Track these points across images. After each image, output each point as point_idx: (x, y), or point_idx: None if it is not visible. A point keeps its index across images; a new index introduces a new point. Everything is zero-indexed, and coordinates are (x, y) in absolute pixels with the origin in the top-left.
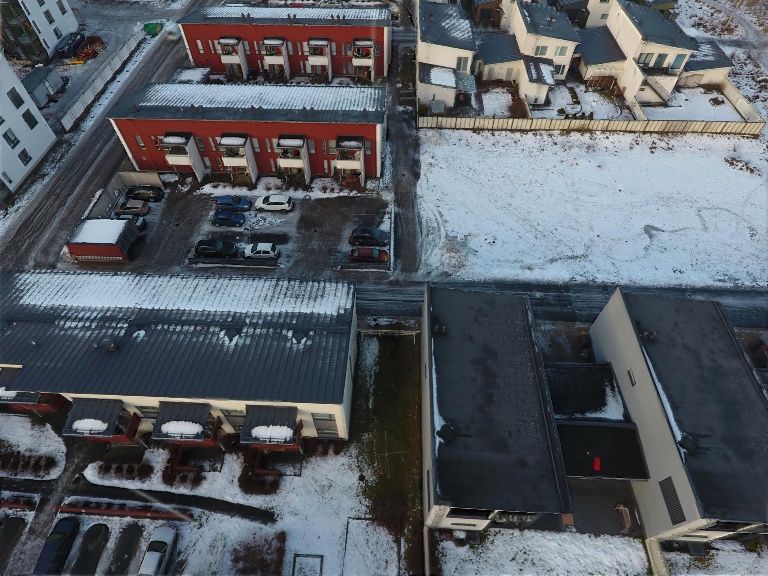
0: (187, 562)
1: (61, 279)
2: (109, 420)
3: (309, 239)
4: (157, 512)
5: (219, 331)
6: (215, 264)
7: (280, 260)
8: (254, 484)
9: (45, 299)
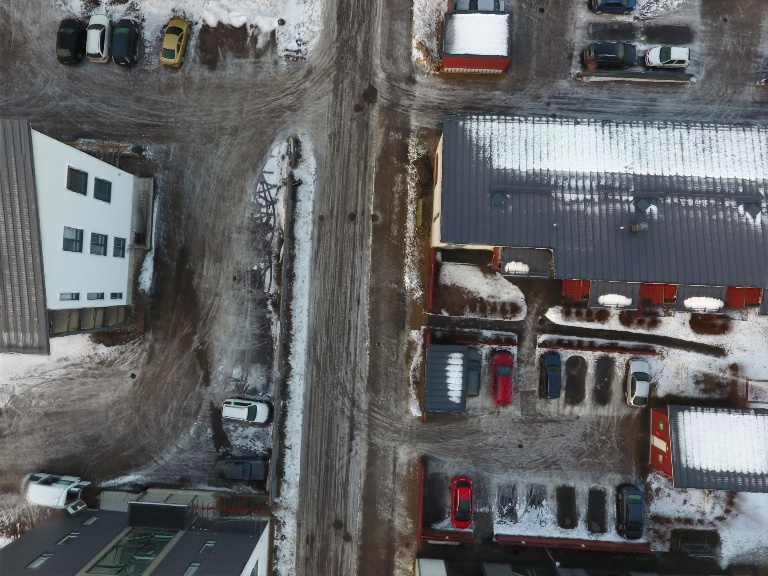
0: (659, 384)
1: (518, 130)
2: (632, 295)
3: (719, 35)
4: (626, 348)
5: (737, 206)
6: (611, 77)
7: (688, 70)
8: (707, 327)
9: (519, 161)
